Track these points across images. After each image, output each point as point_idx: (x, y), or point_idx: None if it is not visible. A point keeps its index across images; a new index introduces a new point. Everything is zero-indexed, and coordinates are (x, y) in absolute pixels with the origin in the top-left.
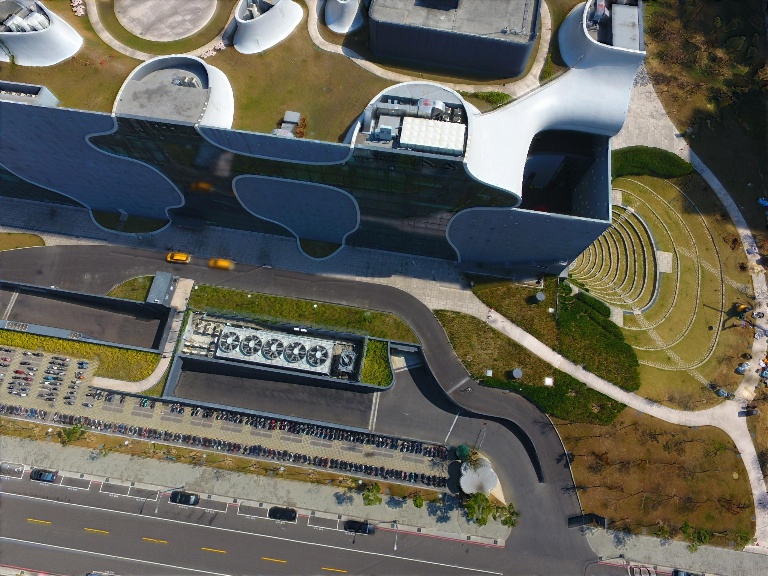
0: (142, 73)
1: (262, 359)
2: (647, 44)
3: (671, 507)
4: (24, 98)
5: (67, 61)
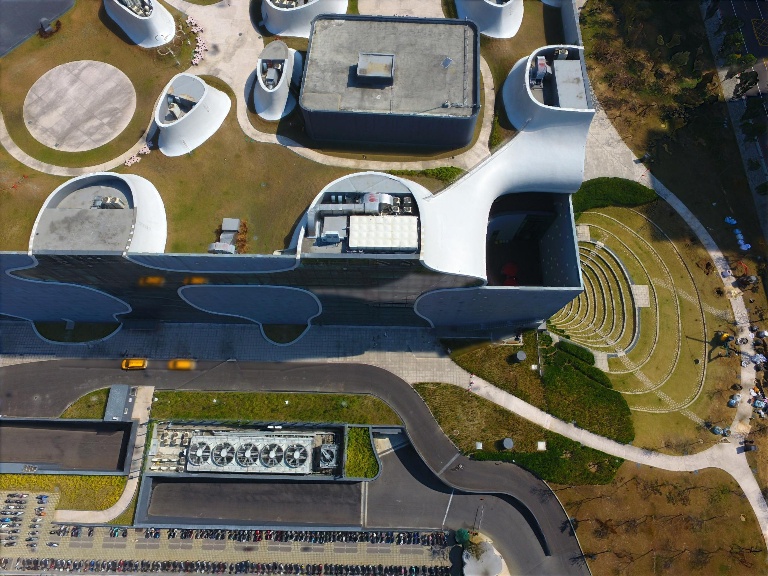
0: (59, 197)
1: (237, 467)
2: (594, 69)
3: (683, 562)
4: None
5: None
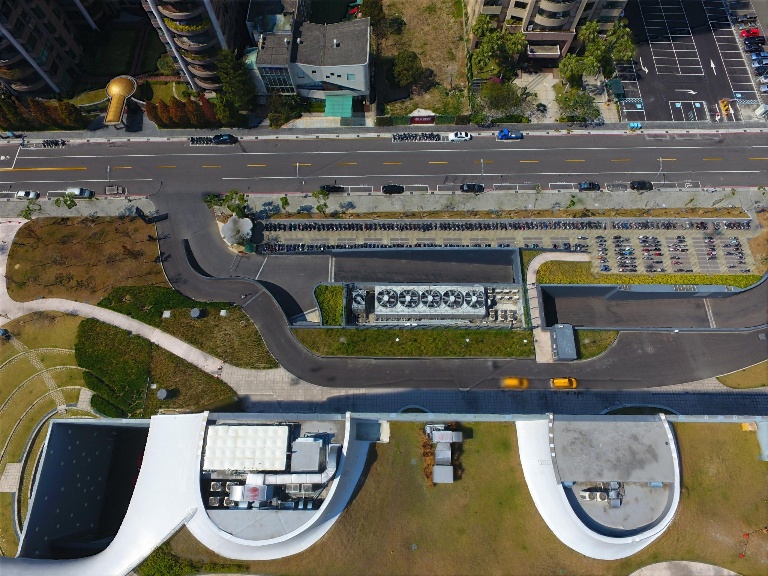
0: None
1: (439, 289)
2: None
3: (81, 236)
4: None
5: None
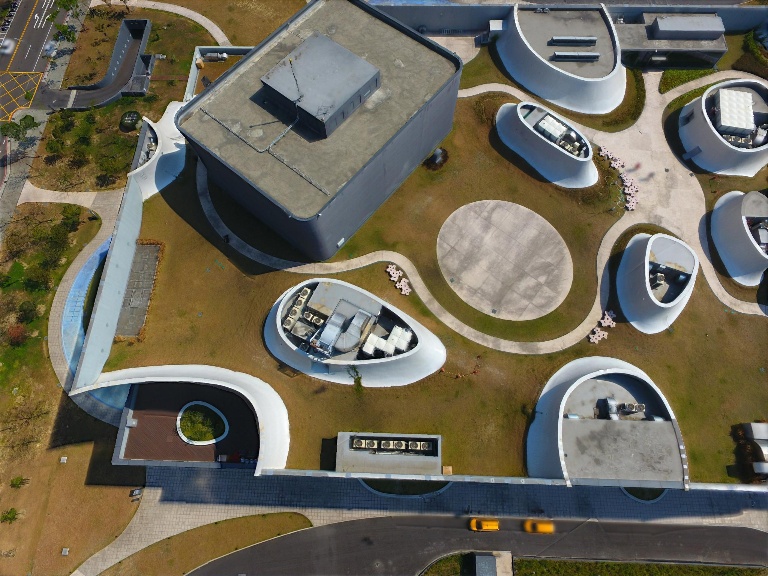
0: None
1: None
2: None
3: None
4: (423, 460)
5: (433, 376)
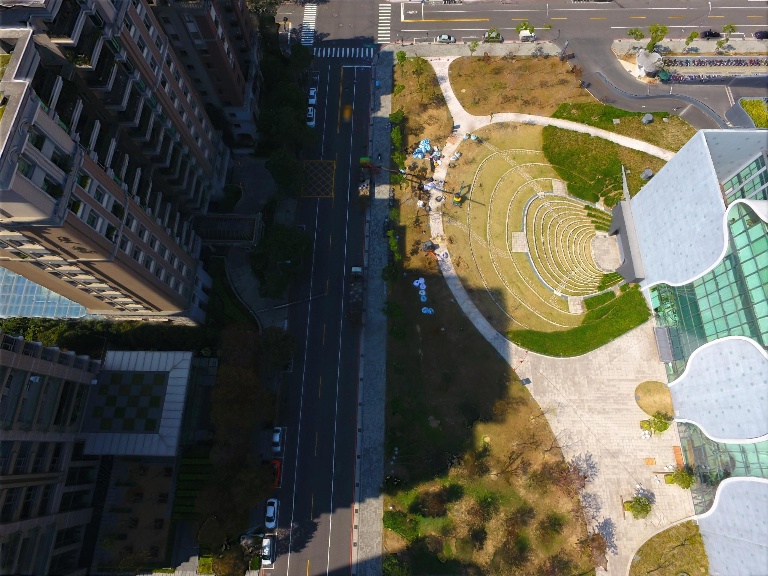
0: None
1: None
2: (579, 543)
3: (509, 69)
4: None
5: None
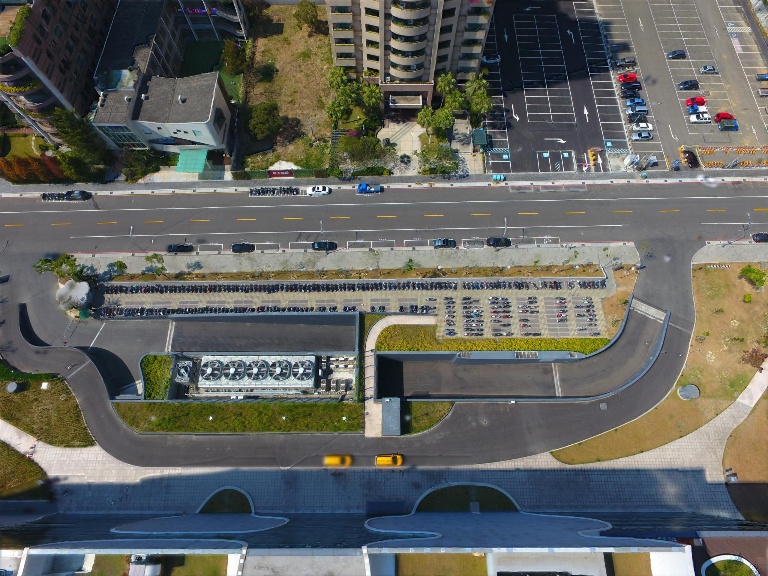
0: None
1: (268, 359)
2: None
3: None
4: (513, 568)
5: None
